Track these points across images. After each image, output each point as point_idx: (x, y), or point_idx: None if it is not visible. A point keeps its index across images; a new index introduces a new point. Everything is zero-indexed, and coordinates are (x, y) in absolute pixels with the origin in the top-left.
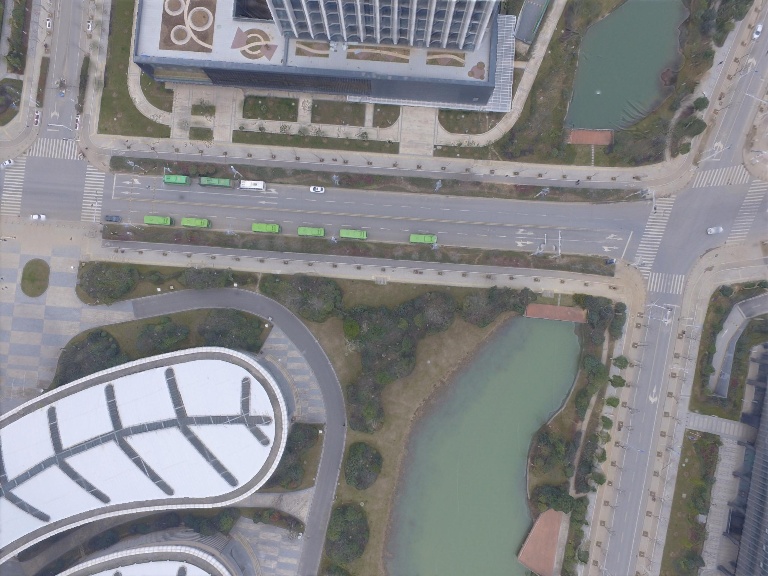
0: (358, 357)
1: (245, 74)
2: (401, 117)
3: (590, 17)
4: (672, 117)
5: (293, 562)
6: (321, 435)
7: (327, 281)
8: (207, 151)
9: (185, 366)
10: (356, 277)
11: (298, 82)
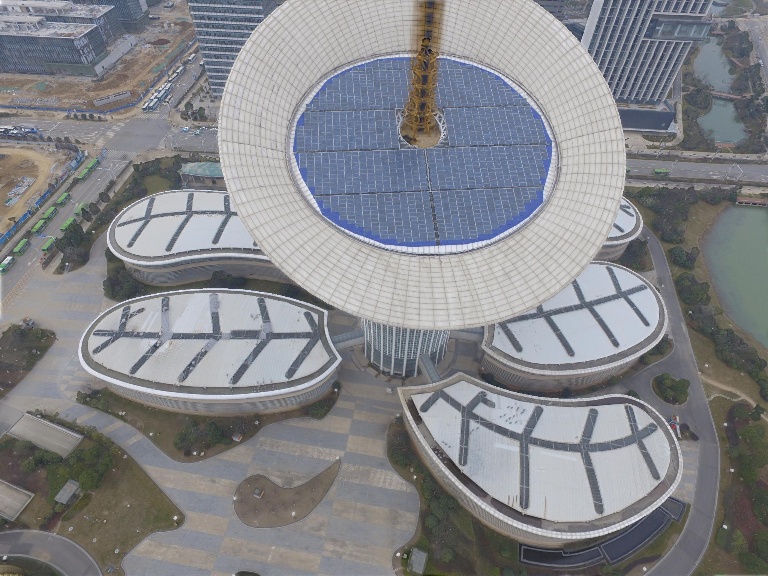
0: (651, 212)
1: None
2: None
3: (696, 114)
4: (760, 140)
5: None
6: (646, 246)
7: None
8: None
9: None
10: (630, 186)
11: None
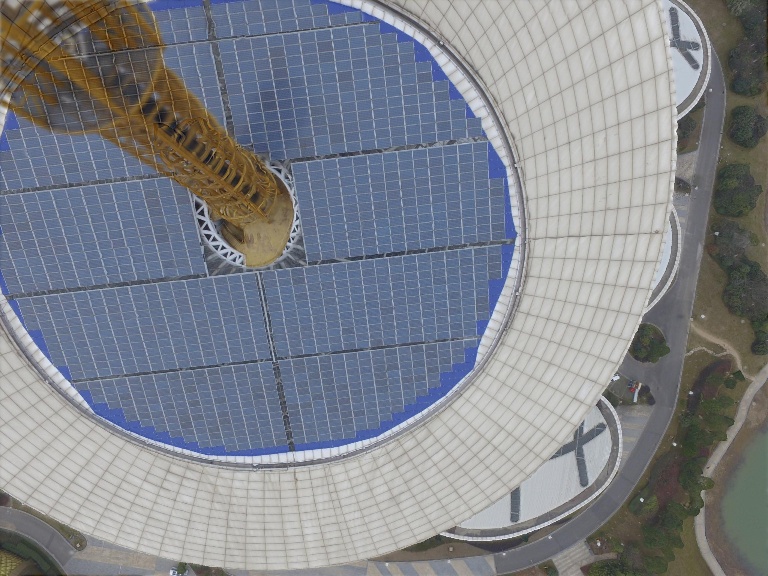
0: (737, 25)
1: None
2: None
3: None
4: None
5: (681, 221)
6: None
7: None
8: None
9: None
10: None
11: None
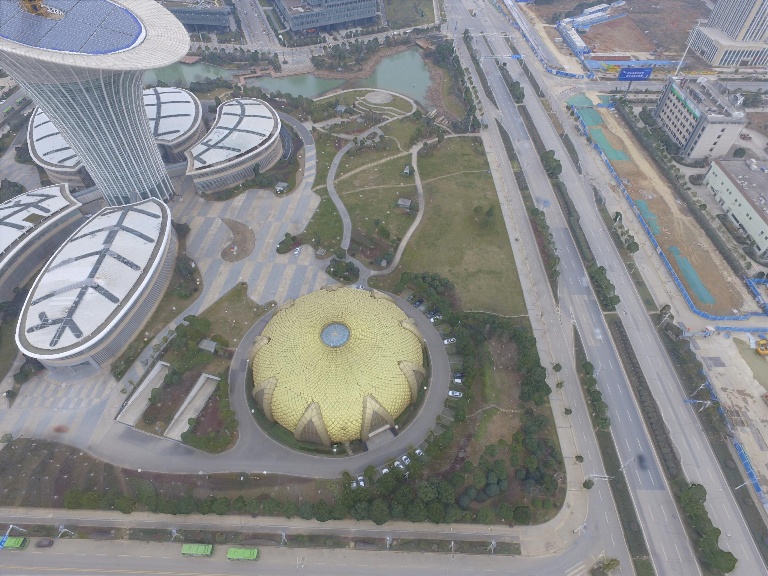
0: None
1: None
2: None
3: None
4: None
5: None
6: None
7: None
8: None
9: None
10: None
11: None
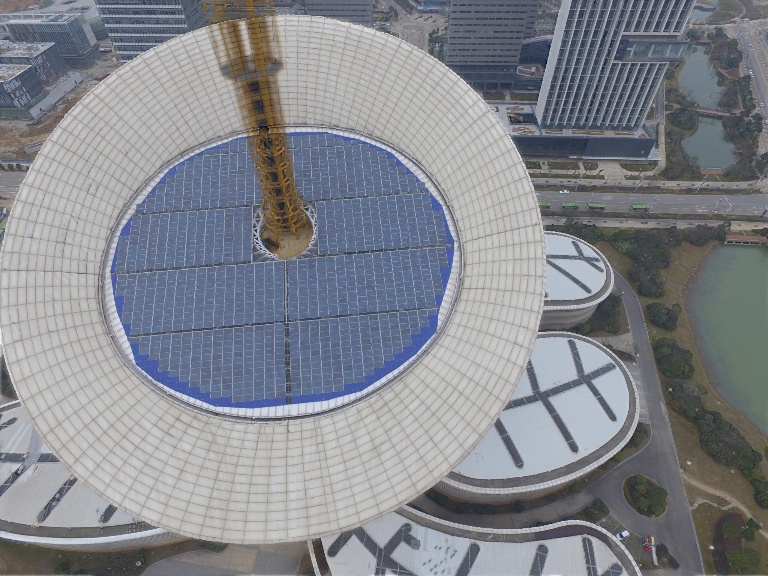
0: (628, 259)
1: (520, 141)
2: (600, 167)
3: (680, 136)
4: None
5: (637, 383)
6: (621, 302)
7: (589, 225)
8: None
9: None
10: (605, 226)
11: (546, 146)
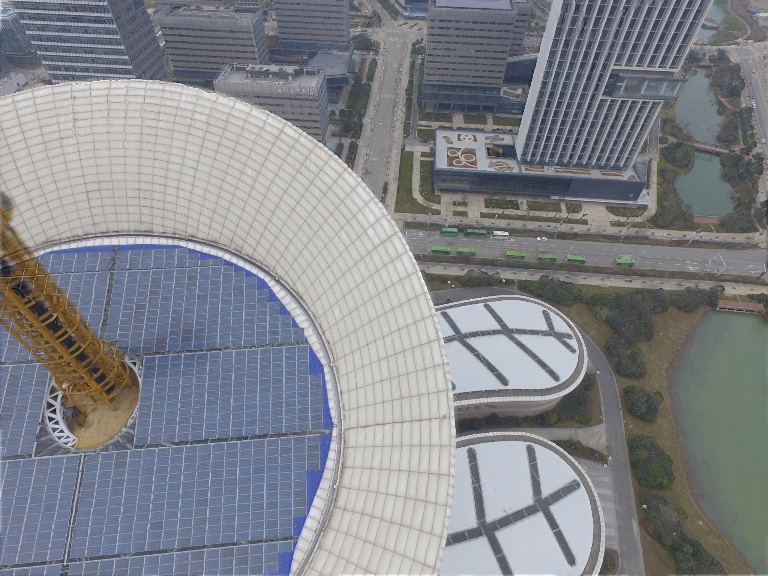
0: (607, 327)
1: (497, 178)
2: (583, 209)
3: (674, 175)
4: (750, 213)
5: (607, 493)
6: None
7: (567, 282)
8: (465, 221)
9: (497, 303)
10: (585, 283)
11: (525, 184)
